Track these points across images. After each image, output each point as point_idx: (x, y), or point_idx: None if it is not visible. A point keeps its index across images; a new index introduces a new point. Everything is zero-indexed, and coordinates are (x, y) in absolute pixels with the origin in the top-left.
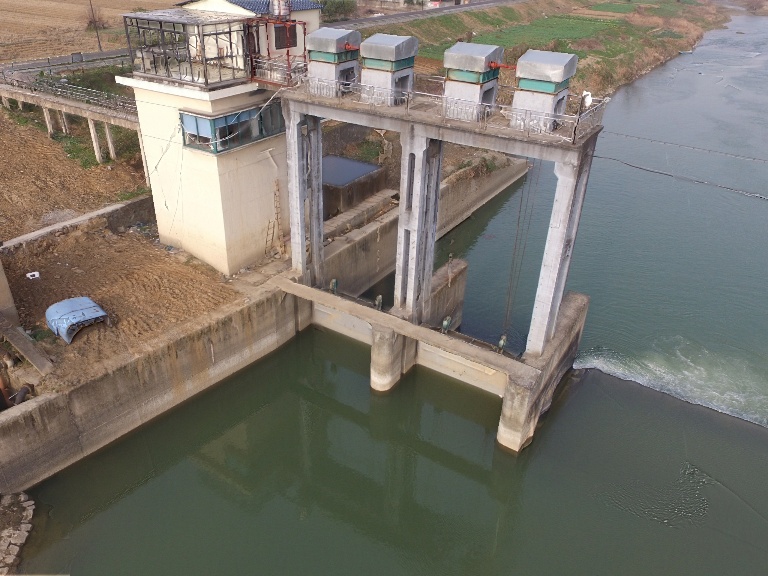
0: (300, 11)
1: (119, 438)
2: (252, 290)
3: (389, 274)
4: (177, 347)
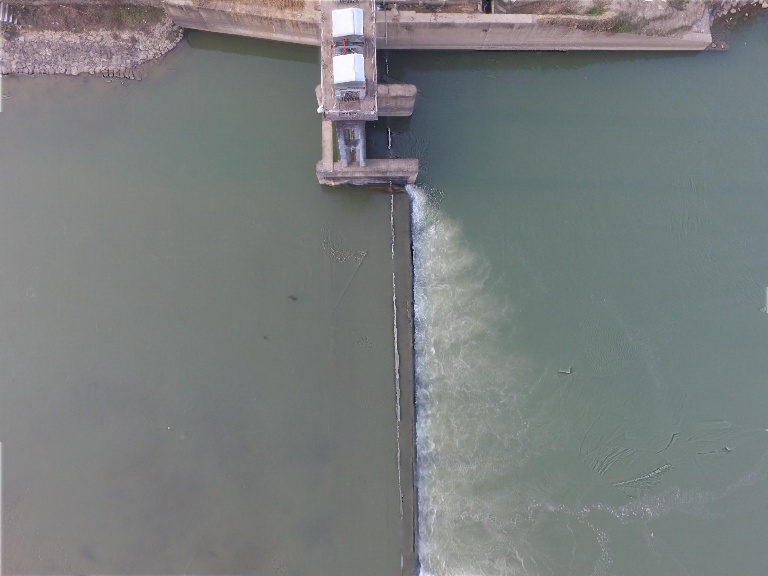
0: None
1: (225, 33)
2: (309, 11)
3: (436, 49)
4: (252, 17)
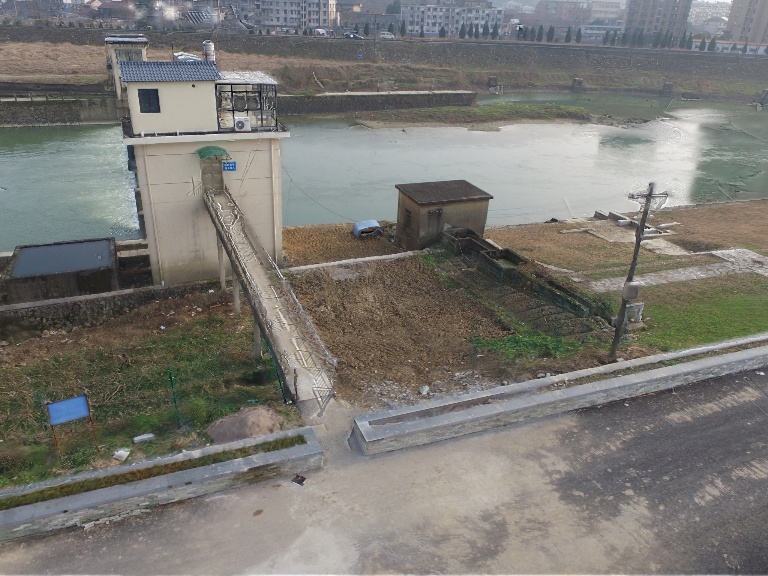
0: None
1: None
2: None
3: None
4: None
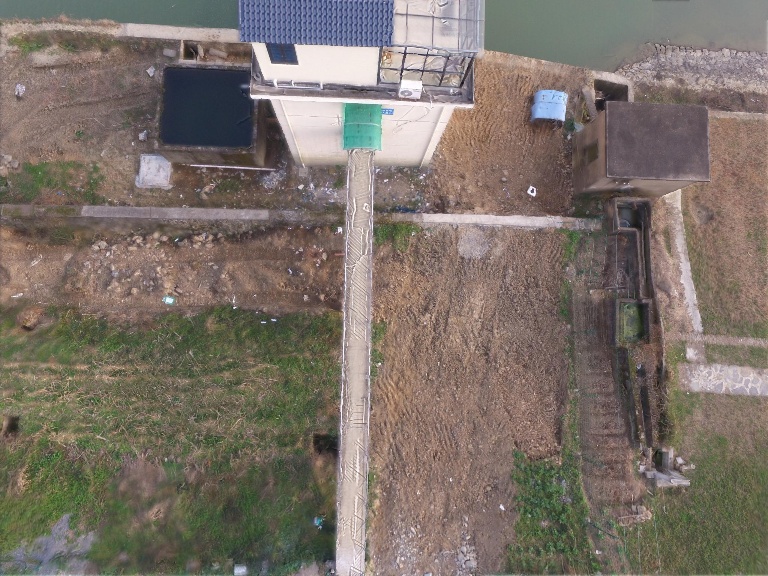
0: None
1: None
2: None
3: None
4: None
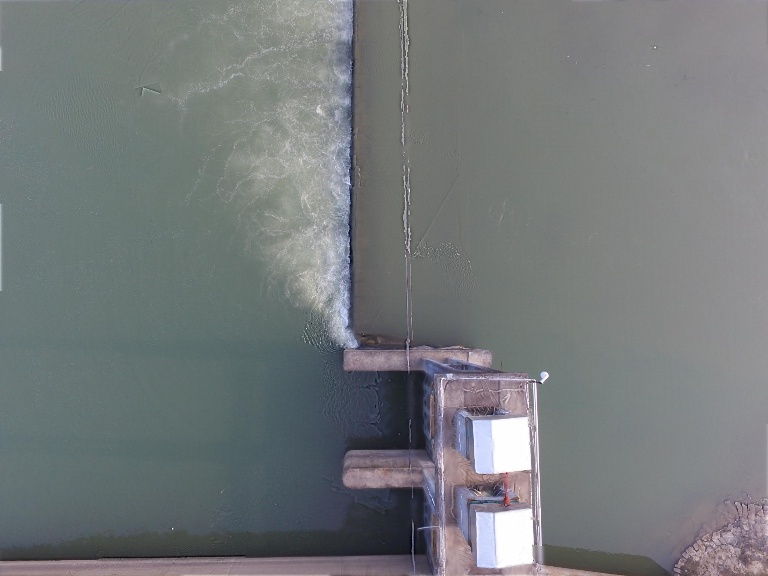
0: None
1: None
2: None
3: None
4: None
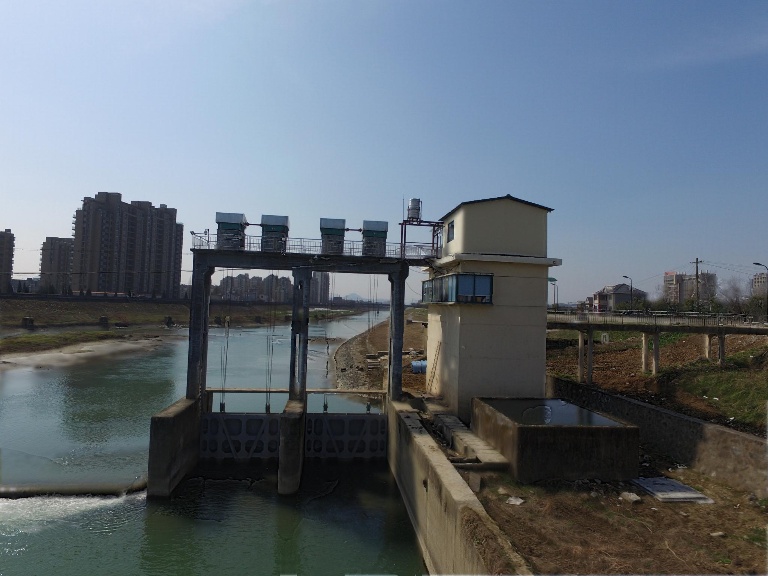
0: (454, 212)
1: None
2: None
3: None
4: None
